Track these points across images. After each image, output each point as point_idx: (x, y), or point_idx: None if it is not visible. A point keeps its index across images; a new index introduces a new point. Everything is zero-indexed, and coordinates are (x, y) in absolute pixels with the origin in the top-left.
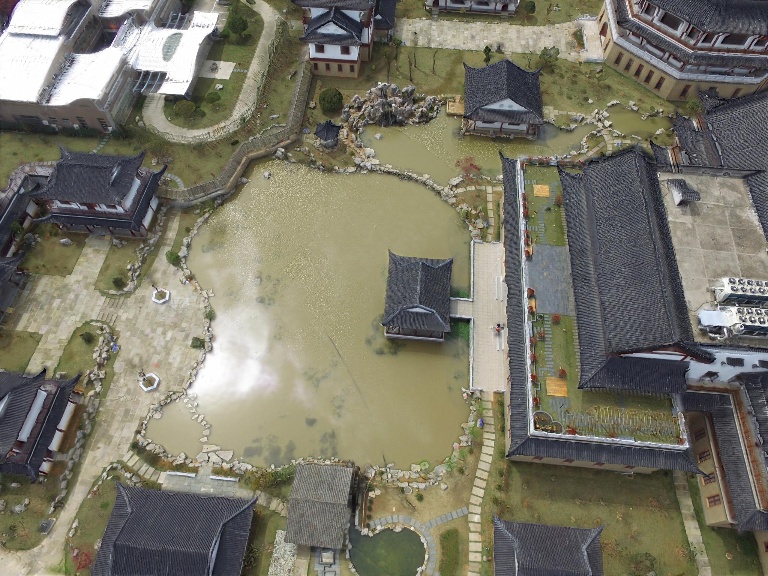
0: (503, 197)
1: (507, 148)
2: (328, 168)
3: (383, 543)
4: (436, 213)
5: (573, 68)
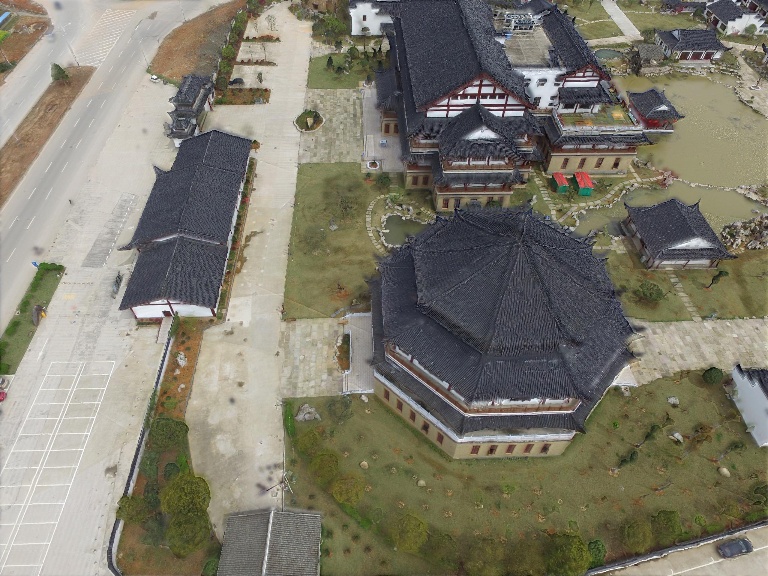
0: None
1: None
2: None
3: None
4: None
5: None
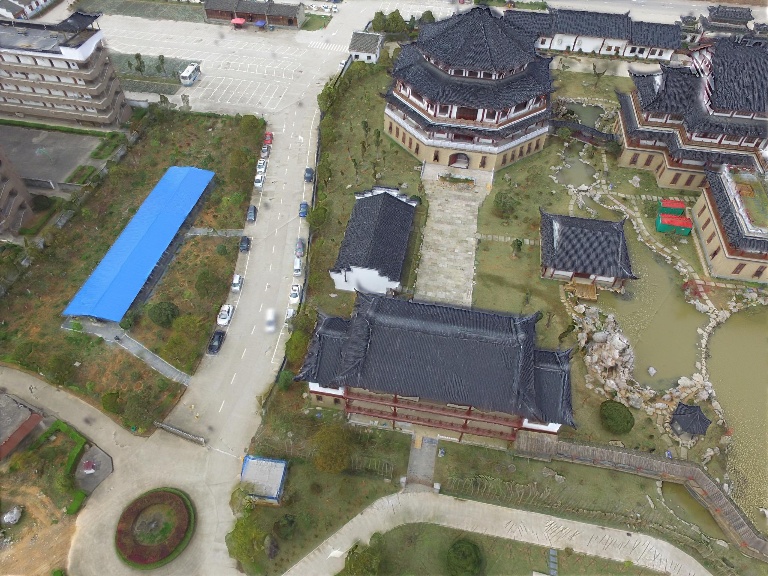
0: (729, 268)
1: (634, 260)
2: (724, 432)
3: None
4: (735, 333)
5: None
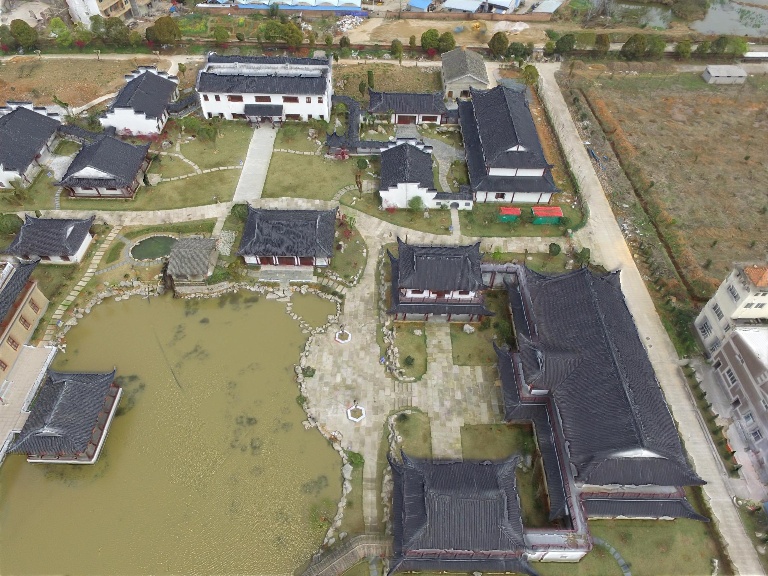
0: None
1: None
2: None
3: (159, 255)
4: None
5: None
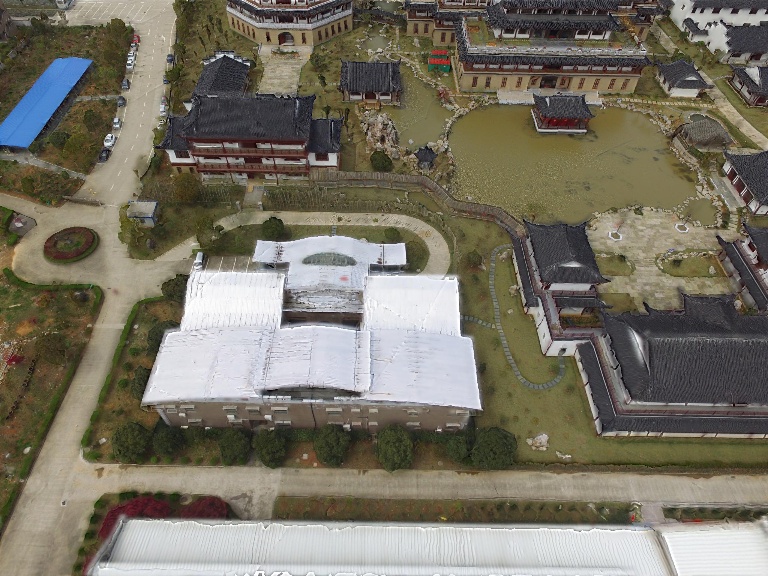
0: (468, 82)
1: (410, 88)
2: None
3: None
4: (473, 122)
5: None
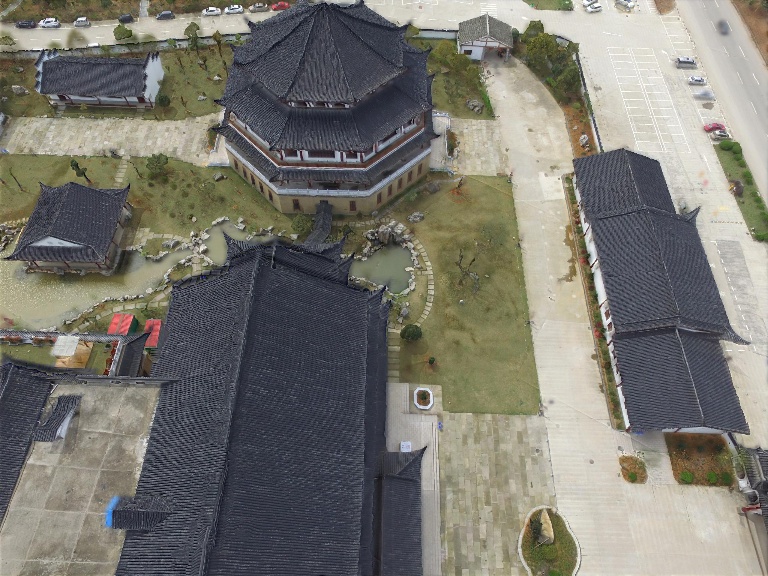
0: None
1: (72, 288)
2: None
3: None
4: None
5: (192, 175)
